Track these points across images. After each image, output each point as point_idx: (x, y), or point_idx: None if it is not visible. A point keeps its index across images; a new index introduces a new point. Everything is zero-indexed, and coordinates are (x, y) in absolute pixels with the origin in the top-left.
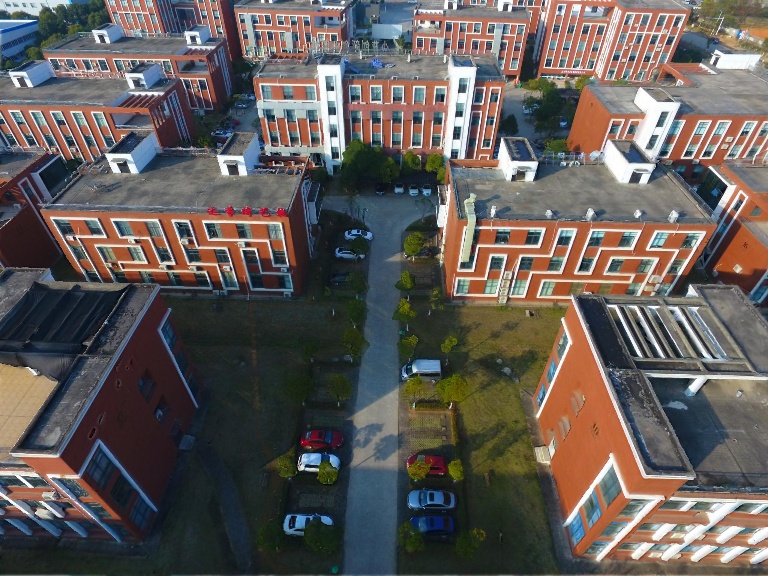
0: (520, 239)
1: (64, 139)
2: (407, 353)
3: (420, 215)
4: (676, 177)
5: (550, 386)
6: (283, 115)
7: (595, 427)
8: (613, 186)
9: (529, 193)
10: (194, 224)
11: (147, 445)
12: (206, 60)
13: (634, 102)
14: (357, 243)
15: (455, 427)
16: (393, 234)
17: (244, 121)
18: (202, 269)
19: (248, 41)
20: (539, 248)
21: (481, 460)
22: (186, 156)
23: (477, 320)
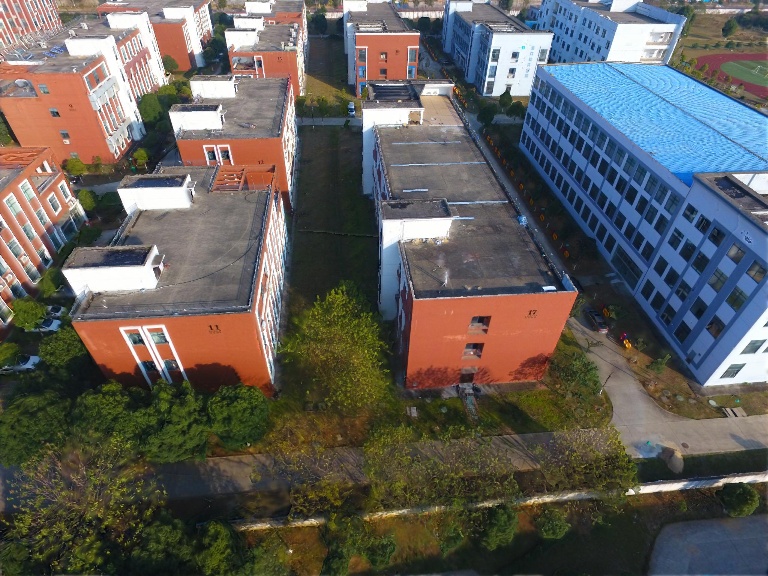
0: None
1: (10, 251)
2: None
3: None
4: None
5: None
6: None
7: (397, 51)
8: None
9: (270, 42)
10: None
11: None
12: None
13: (166, 18)
14: None
15: None
16: None
17: None
18: None
19: None
20: None
21: None
22: None
23: (315, 102)
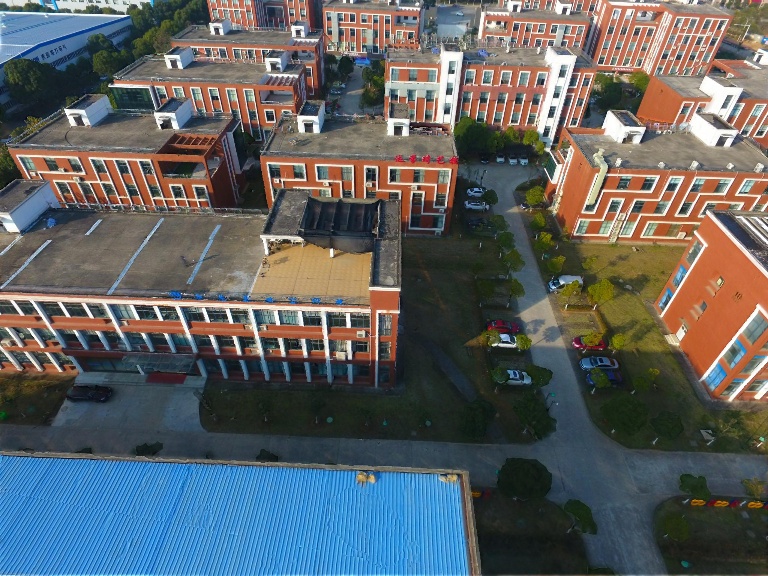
0: (638, 185)
1: None
2: (557, 269)
3: (524, 179)
4: (752, 142)
5: (679, 286)
6: (406, 94)
7: (738, 294)
8: (703, 148)
9: (639, 152)
10: (381, 170)
11: None
12: (315, 50)
13: (699, 89)
14: (491, 194)
15: (602, 321)
16: (506, 193)
17: (343, 105)
18: None
19: (332, 37)
20: (651, 193)
21: (627, 342)
22: (349, 122)
23: (595, 253)
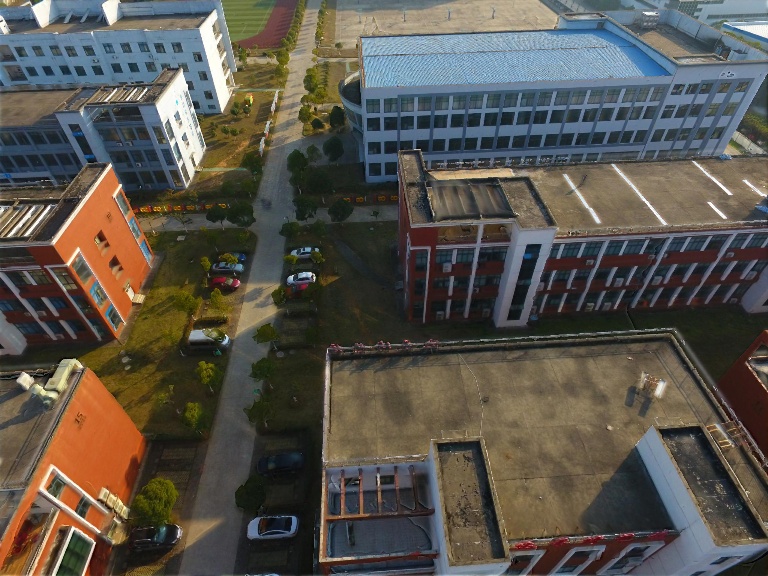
0: None
1: None
2: None
3: None
4: None
5: None
6: None
7: (108, 216)
8: None
9: None
10: None
11: None
12: None
13: None
14: (252, 478)
15: None
16: None
17: None
18: None
19: None
20: None
21: None
22: None
23: None
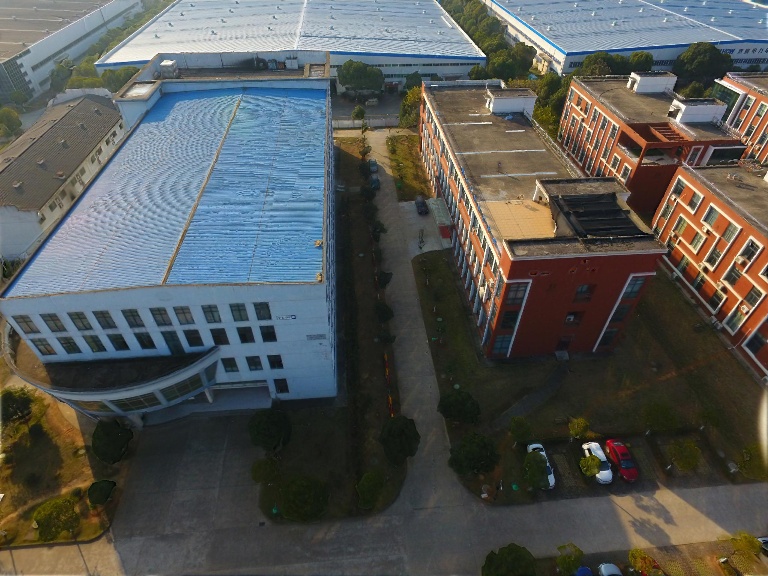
0: None
1: None
2: None
3: None
4: None
5: None
6: None
7: None
8: None
9: None
10: (764, 253)
11: (545, 321)
12: None
13: None
14: None
15: None
16: None
17: None
18: (726, 292)
19: None
20: None
21: None
22: None
23: None
